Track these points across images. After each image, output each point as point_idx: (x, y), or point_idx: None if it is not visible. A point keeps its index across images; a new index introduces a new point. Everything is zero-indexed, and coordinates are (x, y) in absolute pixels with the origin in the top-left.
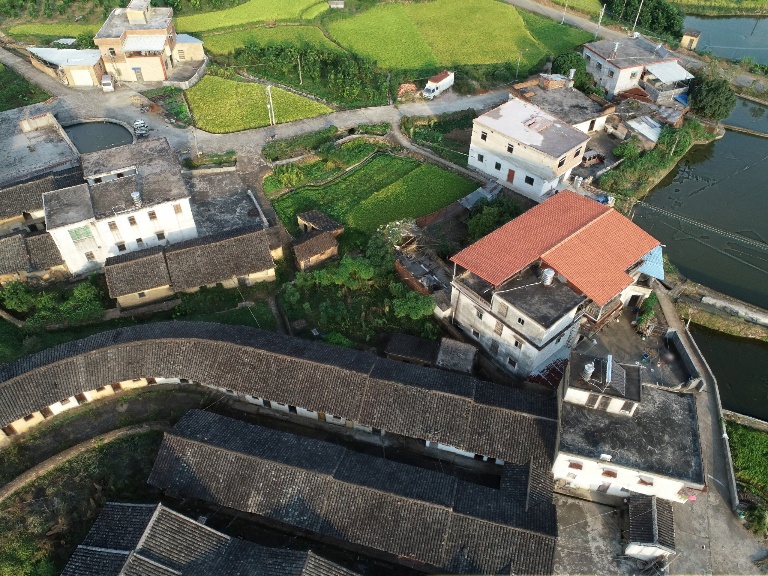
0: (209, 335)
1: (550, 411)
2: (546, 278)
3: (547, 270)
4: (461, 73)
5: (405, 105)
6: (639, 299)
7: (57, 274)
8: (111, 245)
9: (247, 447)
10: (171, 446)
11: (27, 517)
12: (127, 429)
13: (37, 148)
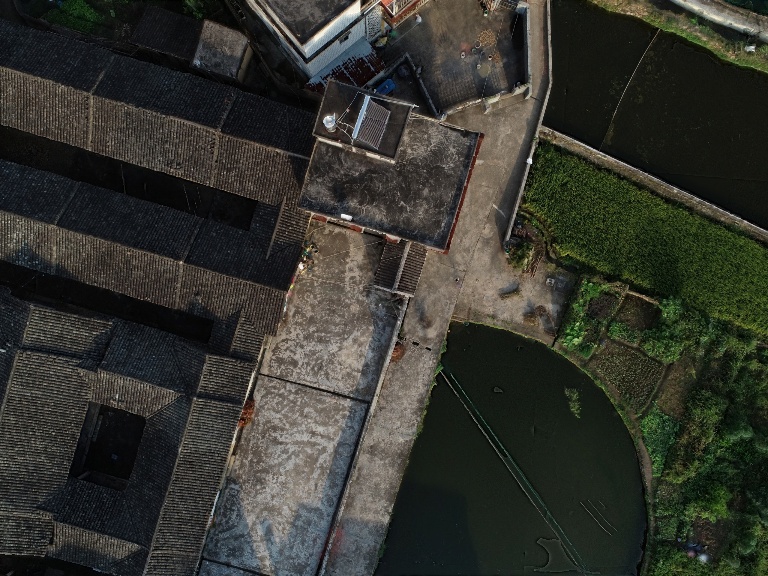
0: None
1: (313, 143)
2: None
3: None
4: None
5: None
6: None
7: None
8: None
9: None
10: None
11: None
12: None
13: None
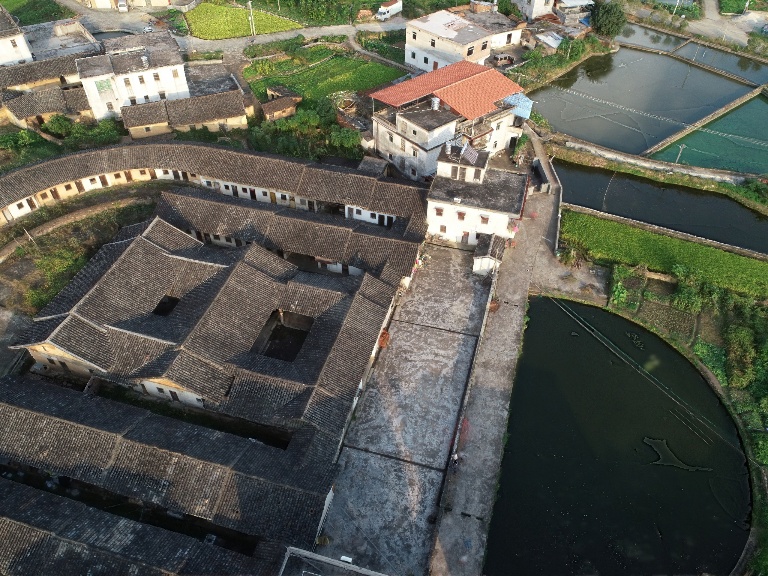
0: (195, 145)
1: None
2: (434, 104)
3: (434, 98)
4: (410, 3)
5: (361, 25)
6: (517, 141)
7: (85, 119)
8: (125, 99)
9: (218, 201)
10: (166, 199)
11: (69, 239)
12: (136, 199)
13: (68, 46)
